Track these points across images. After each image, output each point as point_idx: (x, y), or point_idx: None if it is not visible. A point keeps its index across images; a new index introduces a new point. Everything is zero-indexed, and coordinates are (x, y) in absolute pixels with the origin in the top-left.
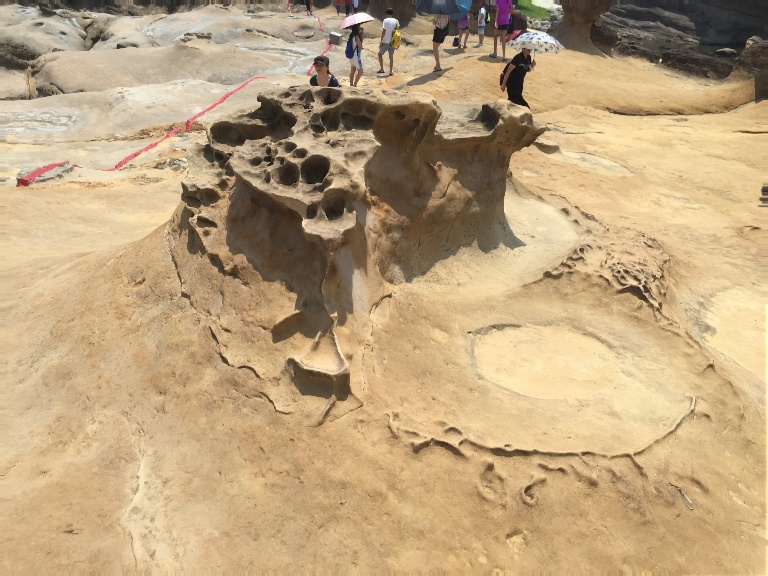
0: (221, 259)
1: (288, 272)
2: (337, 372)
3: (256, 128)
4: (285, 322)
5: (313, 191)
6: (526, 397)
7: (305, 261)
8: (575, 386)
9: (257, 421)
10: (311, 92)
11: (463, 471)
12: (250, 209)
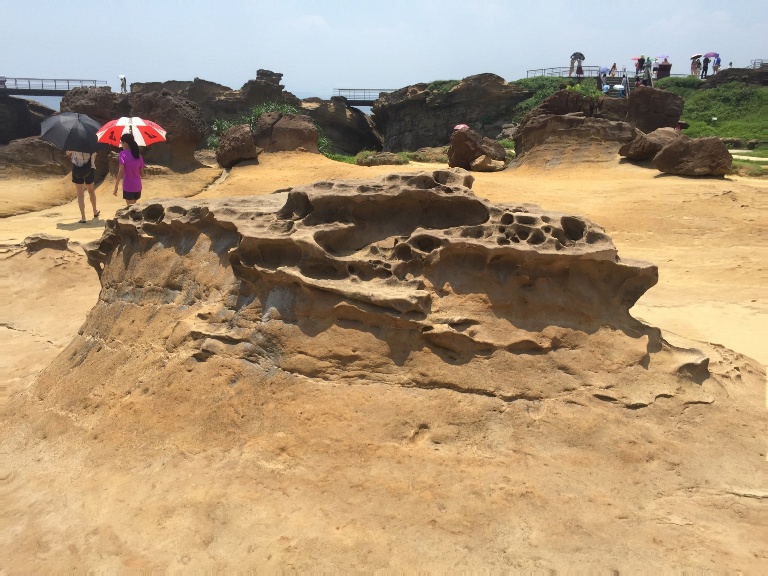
0: (535, 341)
1: (603, 317)
2: None
3: None
4: None
5: None
6: None
7: (604, 303)
8: None
9: (716, 416)
10: (430, 177)
11: None
12: (518, 287)
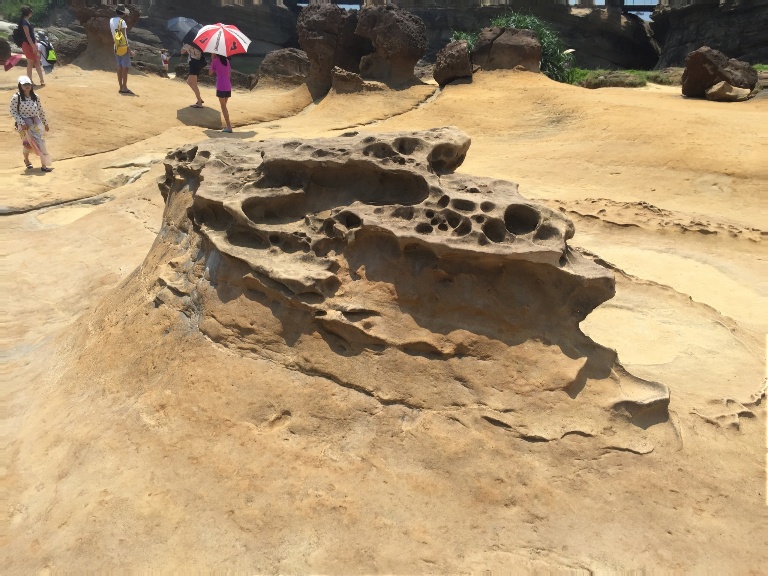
0: (433, 344)
1: (536, 328)
2: (668, 394)
3: (293, 197)
4: (579, 374)
5: (535, 240)
6: (667, 364)
7: (545, 311)
8: (662, 344)
9: (638, 472)
10: (388, 145)
11: (764, 427)
12: (434, 281)
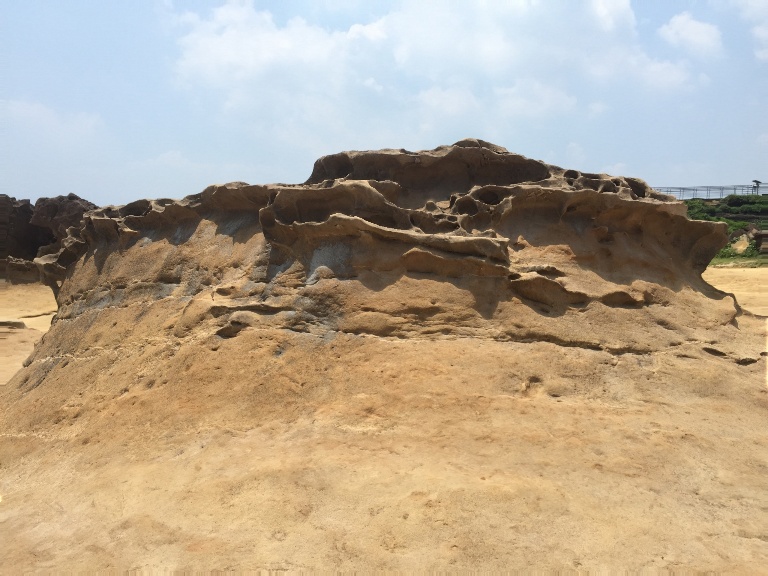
0: None
1: None
2: None
3: (396, 190)
4: None
5: None
6: None
7: (678, 265)
8: None
9: None
10: (475, 142)
11: None
12: (596, 240)
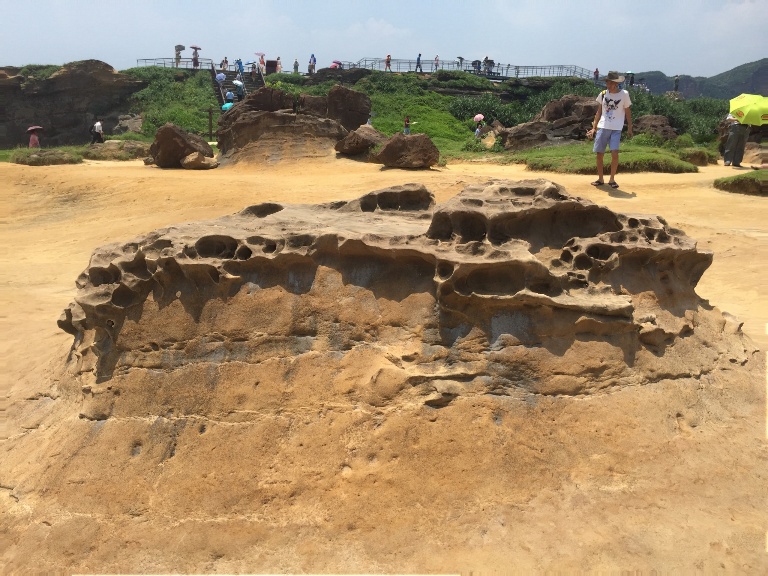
0: None
1: None
2: None
3: None
4: None
5: None
6: None
7: None
8: None
9: None
10: (556, 188)
11: None
12: None
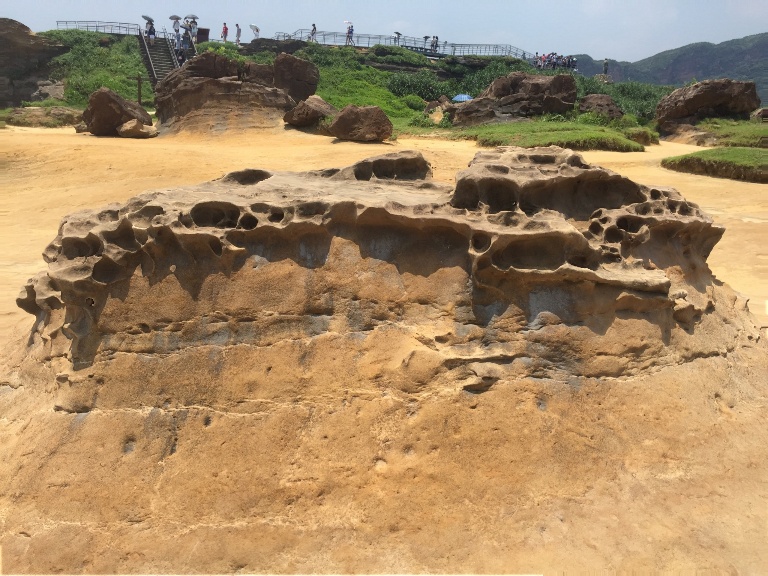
0: None
1: None
2: None
3: None
4: None
5: None
6: None
7: None
8: None
9: None
10: None
11: None
12: None
